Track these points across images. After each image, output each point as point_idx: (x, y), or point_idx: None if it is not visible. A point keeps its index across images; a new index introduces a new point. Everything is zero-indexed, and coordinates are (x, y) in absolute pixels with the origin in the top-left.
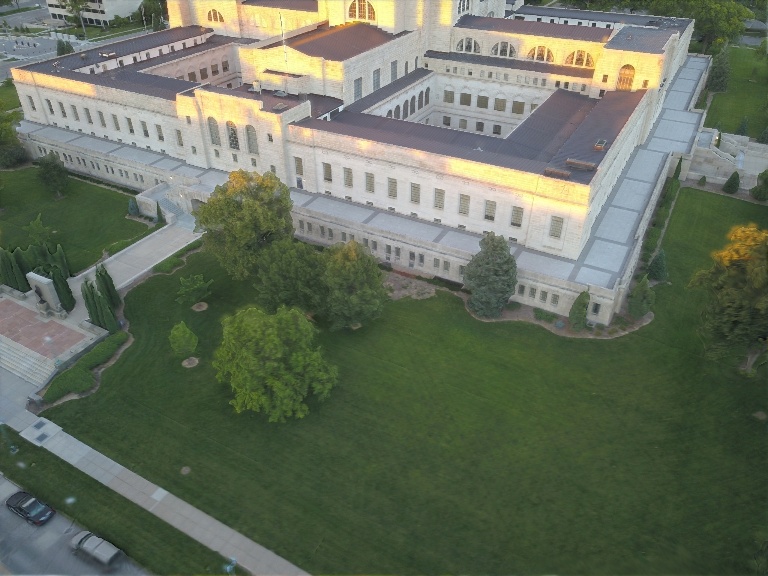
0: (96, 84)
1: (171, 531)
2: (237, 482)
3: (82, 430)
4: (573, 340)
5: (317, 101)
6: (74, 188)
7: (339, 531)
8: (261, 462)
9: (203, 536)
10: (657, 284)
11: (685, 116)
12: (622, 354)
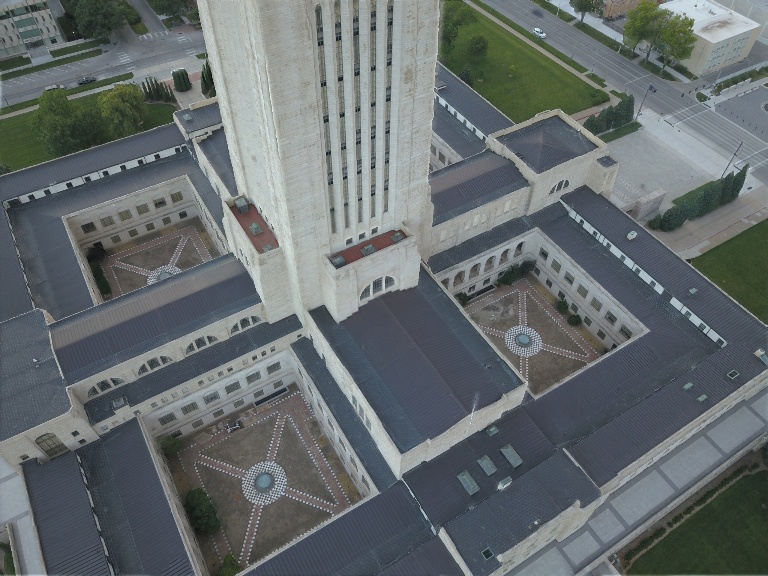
0: None
1: None
2: None
3: None
4: None
5: None
6: None
7: None
8: None
9: None
10: None
11: (6, 502)
12: None
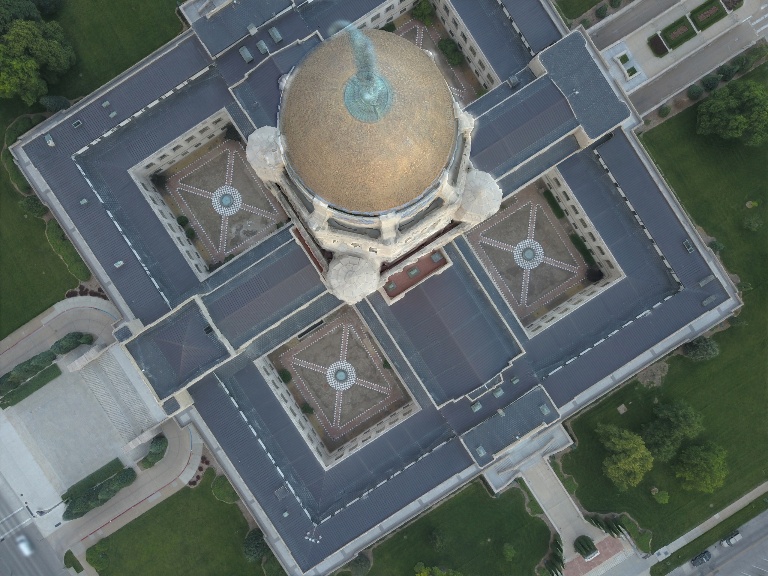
0: (384, 513)
1: (734, 515)
2: (727, 490)
3: (671, 539)
4: (733, 326)
5: (510, 368)
6: (431, 525)
7: (764, 464)
8: (724, 480)
9: (741, 506)
10: (719, 252)
11: None
12: (751, 312)
